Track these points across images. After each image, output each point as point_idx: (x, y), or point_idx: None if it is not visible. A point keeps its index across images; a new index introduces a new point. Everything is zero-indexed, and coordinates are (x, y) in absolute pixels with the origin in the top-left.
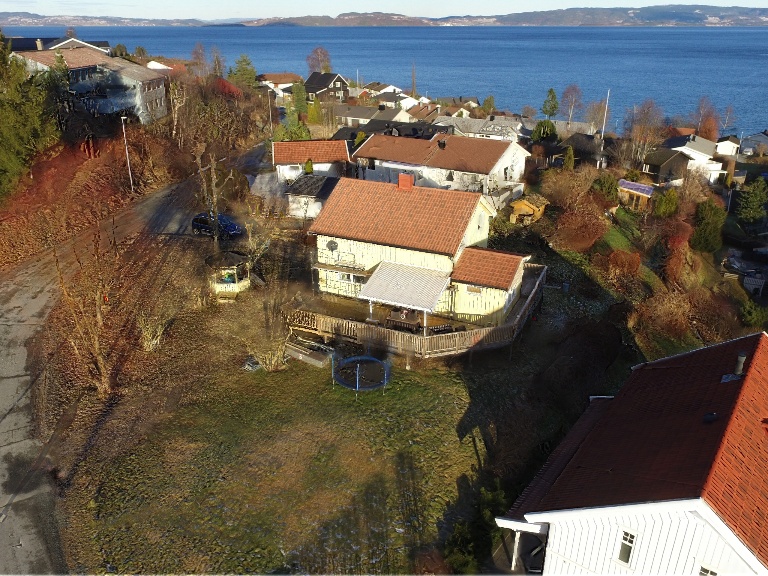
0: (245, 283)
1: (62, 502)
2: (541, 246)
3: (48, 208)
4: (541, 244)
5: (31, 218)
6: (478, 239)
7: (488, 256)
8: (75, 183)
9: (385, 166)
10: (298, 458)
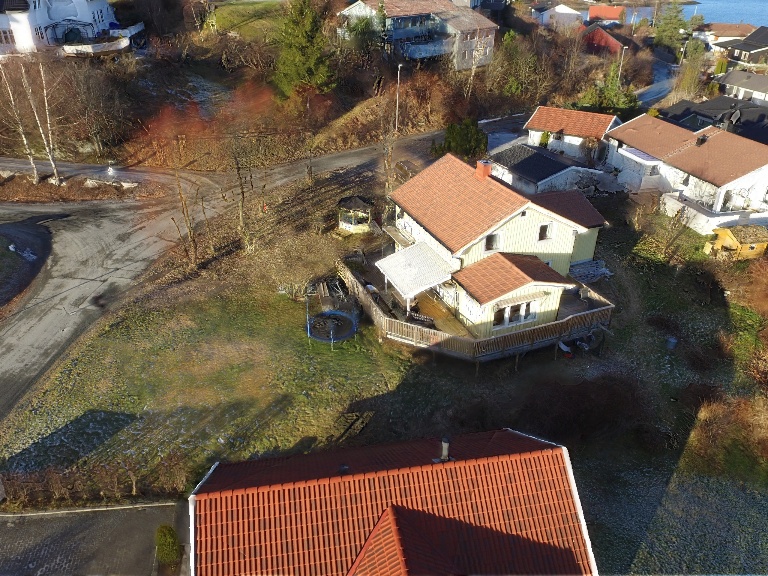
0: (364, 227)
1: (101, 319)
2: (713, 290)
3: (312, 131)
4: (713, 288)
5: (293, 137)
6: (541, 250)
7: (507, 267)
8: (348, 115)
9: (620, 152)
10: (224, 361)
